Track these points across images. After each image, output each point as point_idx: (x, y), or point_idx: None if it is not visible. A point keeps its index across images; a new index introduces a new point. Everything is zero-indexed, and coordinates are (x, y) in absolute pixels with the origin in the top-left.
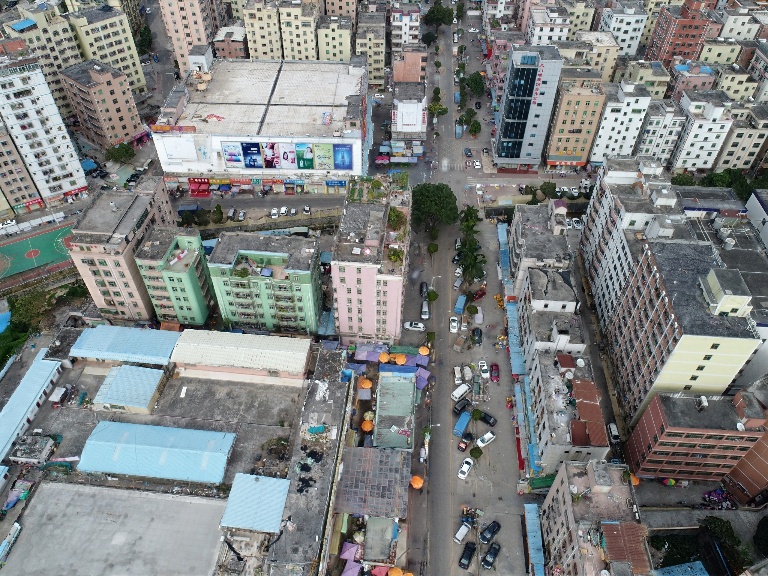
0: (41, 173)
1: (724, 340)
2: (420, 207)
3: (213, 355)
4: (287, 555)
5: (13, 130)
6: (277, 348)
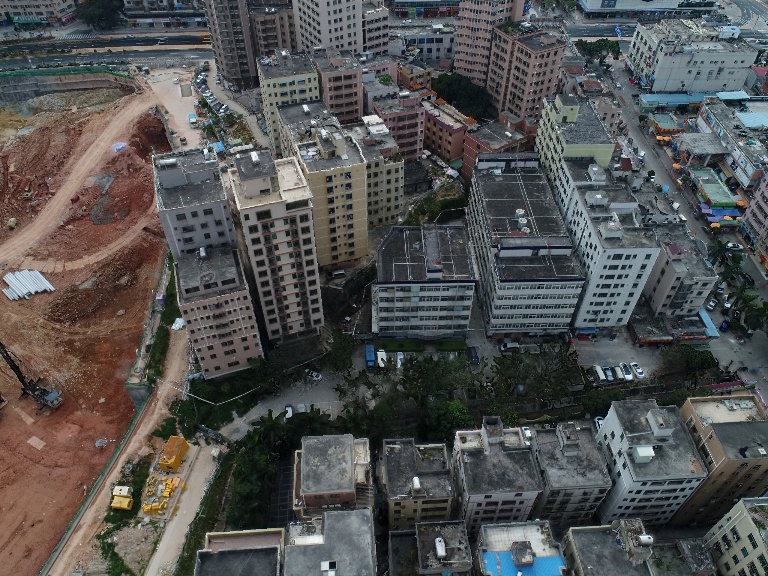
0: None
1: None
2: None
3: None
4: (724, 109)
5: None
6: None
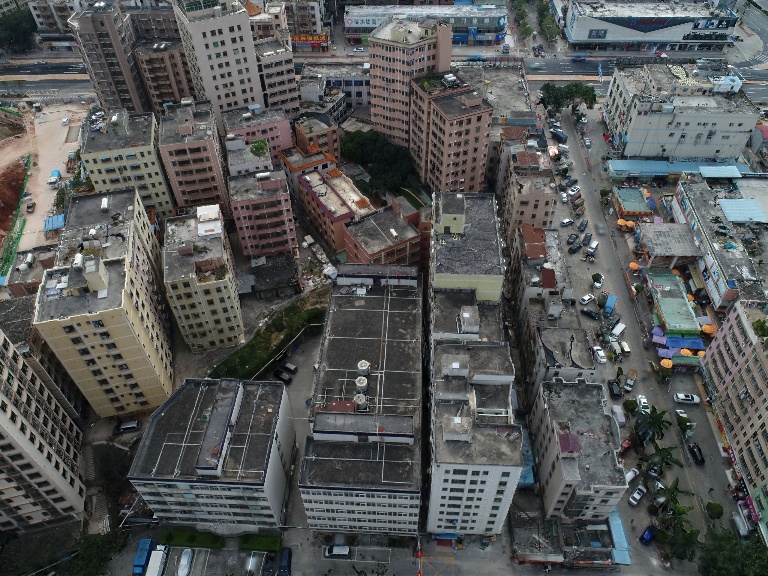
0: None
1: None
2: None
3: None
4: (705, 192)
5: None
6: None
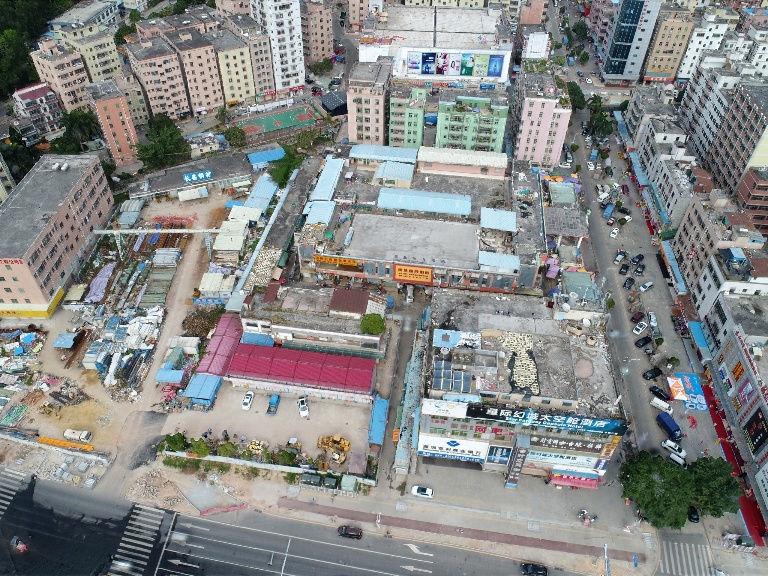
0: (280, 70)
1: None
2: None
3: (445, 158)
4: (525, 241)
5: (272, 34)
6: (487, 155)
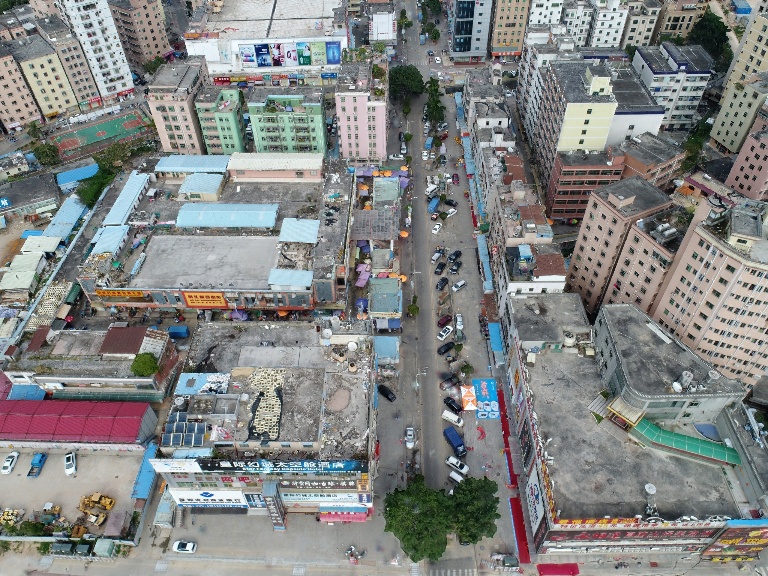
0: (101, 75)
1: (594, 105)
2: (395, 82)
3: (257, 164)
4: (323, 252)
5: (82, 37)
6: (301, 158)
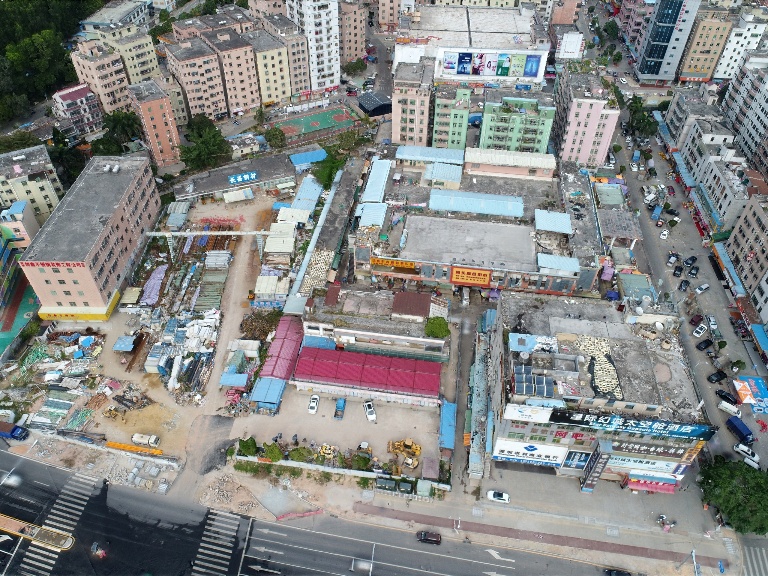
0: (317, 70)
1: None
2: None
3: (493, 159)
4: (582, 243)
5: (310, 34)
6: (534, 157)
